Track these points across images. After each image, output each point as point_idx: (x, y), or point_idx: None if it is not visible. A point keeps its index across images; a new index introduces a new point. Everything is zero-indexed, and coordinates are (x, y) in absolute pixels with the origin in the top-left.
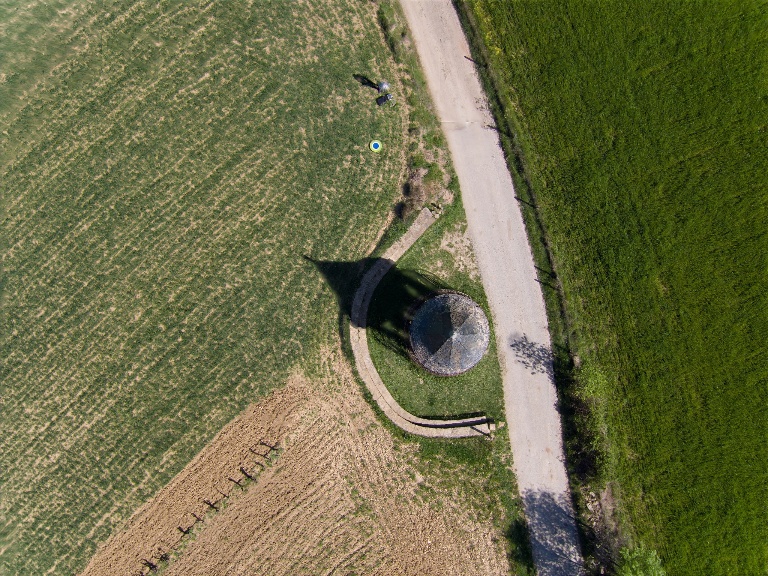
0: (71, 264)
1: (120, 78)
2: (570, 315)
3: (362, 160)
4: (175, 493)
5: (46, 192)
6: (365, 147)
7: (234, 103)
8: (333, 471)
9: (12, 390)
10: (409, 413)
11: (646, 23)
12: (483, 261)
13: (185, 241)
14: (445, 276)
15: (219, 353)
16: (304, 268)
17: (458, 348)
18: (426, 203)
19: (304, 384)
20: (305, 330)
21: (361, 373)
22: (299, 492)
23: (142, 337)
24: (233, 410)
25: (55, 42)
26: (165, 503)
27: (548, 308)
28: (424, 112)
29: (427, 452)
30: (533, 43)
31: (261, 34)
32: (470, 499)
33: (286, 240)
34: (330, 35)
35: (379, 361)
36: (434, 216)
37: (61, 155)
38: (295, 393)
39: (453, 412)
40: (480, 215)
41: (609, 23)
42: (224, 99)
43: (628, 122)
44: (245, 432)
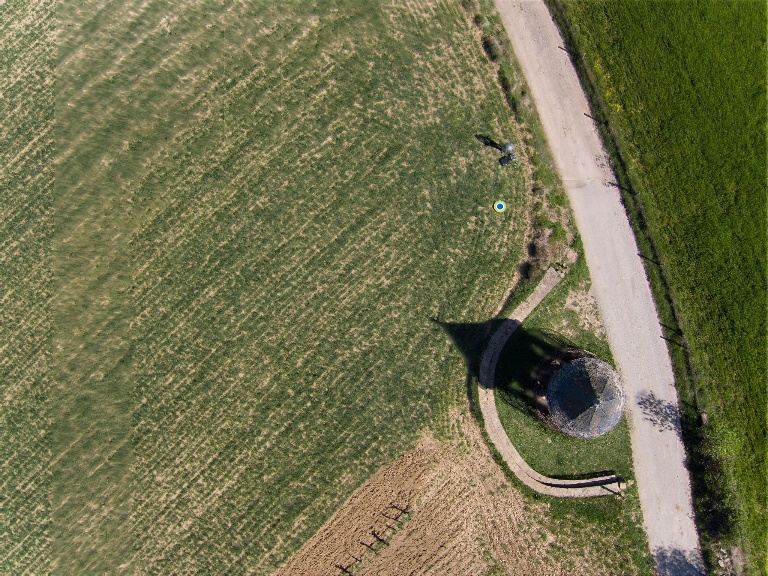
0: (198, 331)
1: (243, 143)
2: (697, 372)
3: (486, 221)
4: (307, 558)
5: (172, 259)
6: (489, 208)
7: (357, 166)
8: (464, 533)
9: (142, 458)
10: (539, 473)
11: (765, 77)
12: (608, 319)
13: (312, 306)
14: (570, 335)
15: (348, 417)
16: (431, 330)
17: (599, 414)
18: (551, 263)
19: (433, 446)
20: (433, 392)
21: (490, 434)
22: (431, 554)
23: (271, 403)
24: (363, 474)
25: (177, 108)
26: (298, 568)
27: (674, 365)
28: (546, 171)
29: (558, 512)
30: (653, 99)
31: (382, 96)
32: (602, 558)
33: (412, 303)
34: (451, 96)
35: (507, 421)
36: (559, 275)
37: (186, 222)
38: (425, 456)
39: (582, 471)
40: (604, 273)
41: (728, 78)
42: (347, 162)
43: (749, 177)
44: (376, 496)
